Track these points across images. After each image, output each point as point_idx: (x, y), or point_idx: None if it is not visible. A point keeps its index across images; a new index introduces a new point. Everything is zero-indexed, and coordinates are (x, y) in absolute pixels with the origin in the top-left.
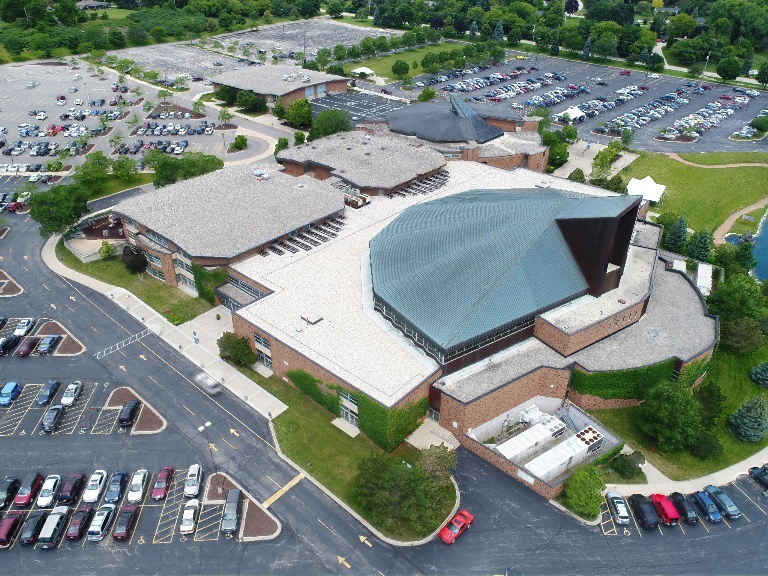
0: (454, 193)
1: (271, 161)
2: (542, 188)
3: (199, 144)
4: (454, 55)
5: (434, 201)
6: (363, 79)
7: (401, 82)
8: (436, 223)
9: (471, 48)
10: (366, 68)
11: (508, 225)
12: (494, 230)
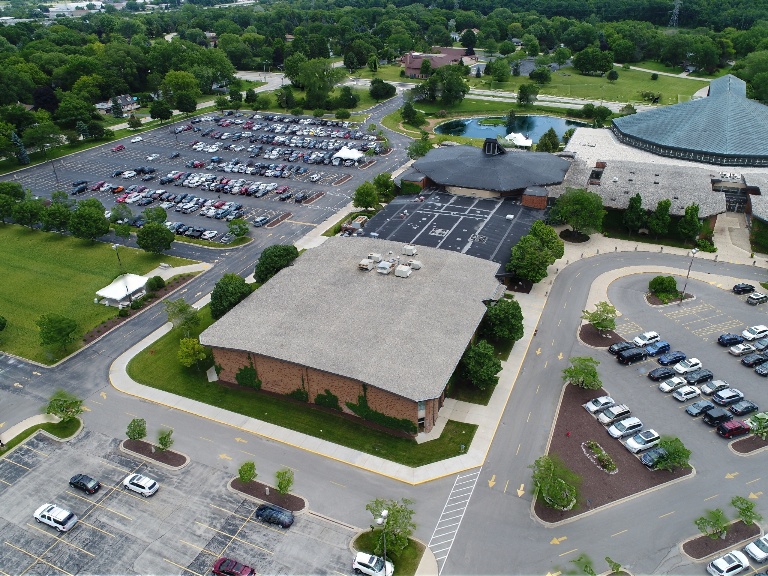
0: (649, 162)
1: (670, 260)
2: (636, 129)
3: (701, 332)
4: (38, 211)
5: (710, 147)
6: (169, 285)
7: (183, 253)
8: (763, 131)
9: (7, 196)
10: (127, 275)
11: (759, 108)
12: (765, 112)
